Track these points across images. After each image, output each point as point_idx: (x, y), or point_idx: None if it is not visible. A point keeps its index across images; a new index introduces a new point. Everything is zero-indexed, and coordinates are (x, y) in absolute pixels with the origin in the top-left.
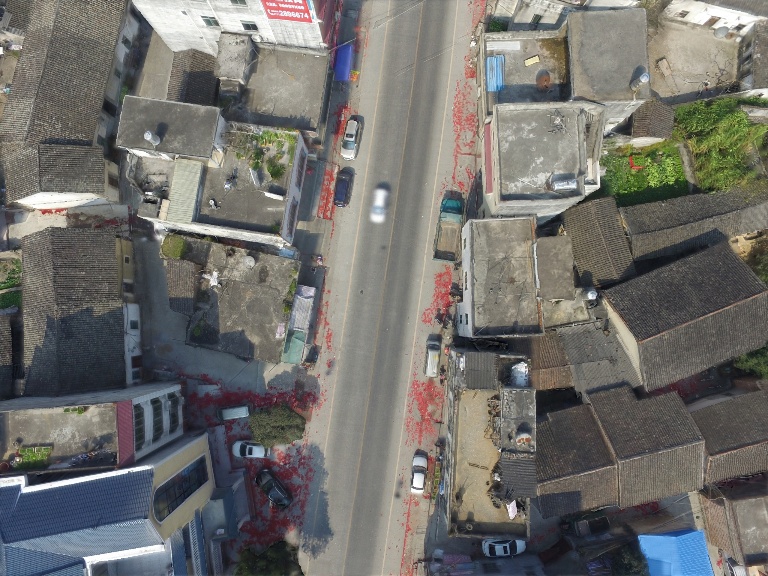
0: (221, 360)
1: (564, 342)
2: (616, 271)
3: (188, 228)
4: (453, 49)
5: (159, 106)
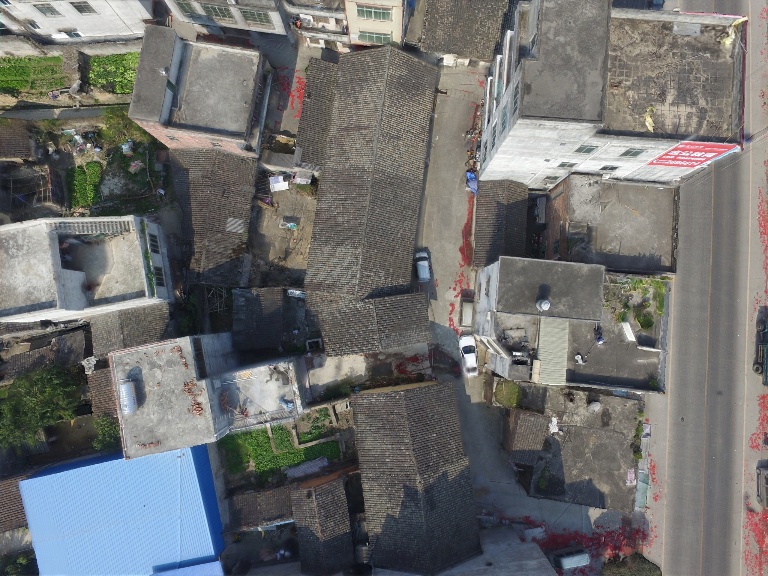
0: (542, 500)
1: None
2: None
3: None
4: (751, 154)
5: (538, 266)
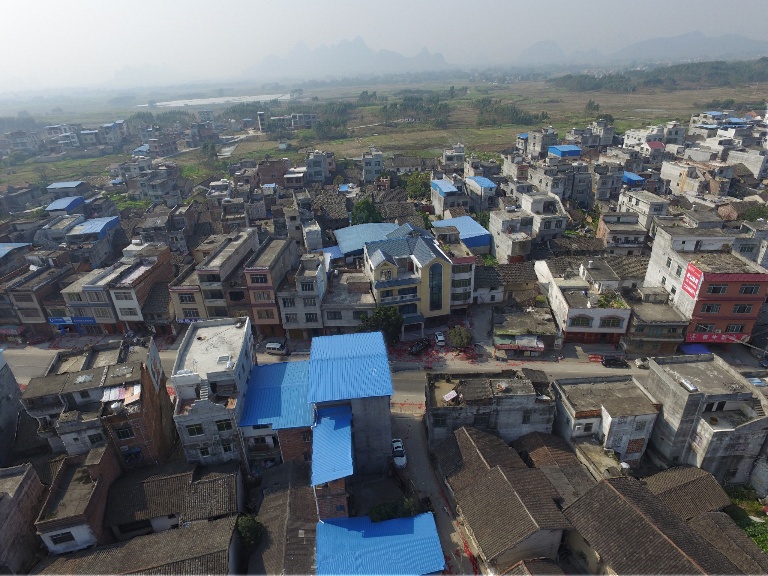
0: (484, 328)
1: (575, 466)
2: (660, 493)
3: None
4: None
5: None
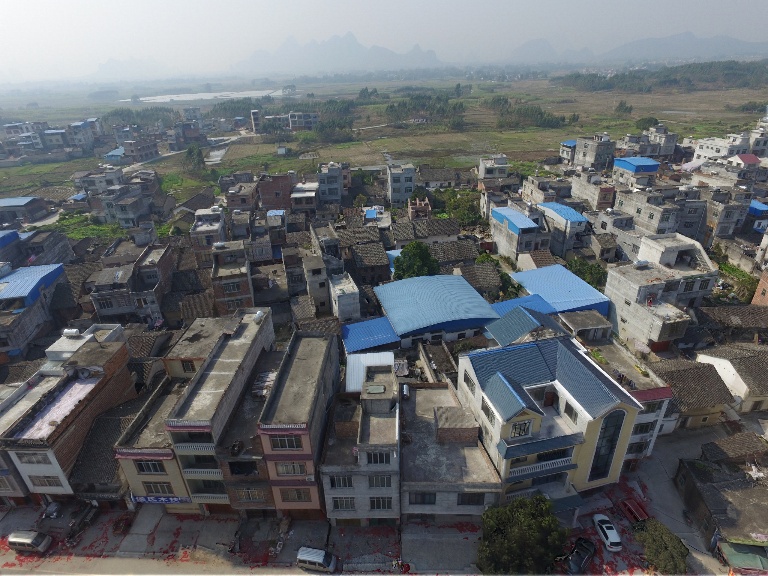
0: (669, 499)
1: None
2: None
3: None
4: None
5: None
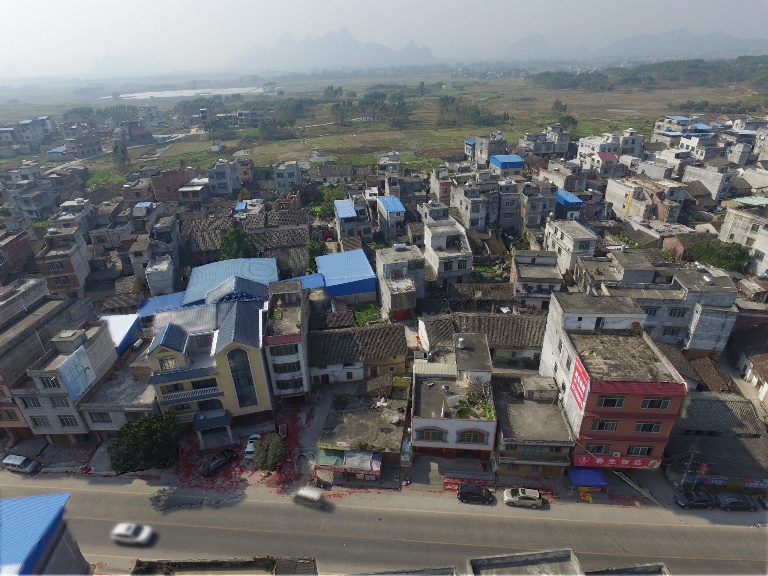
0: None
1: None
2: None
3: None
4: None
5: (484, 347)
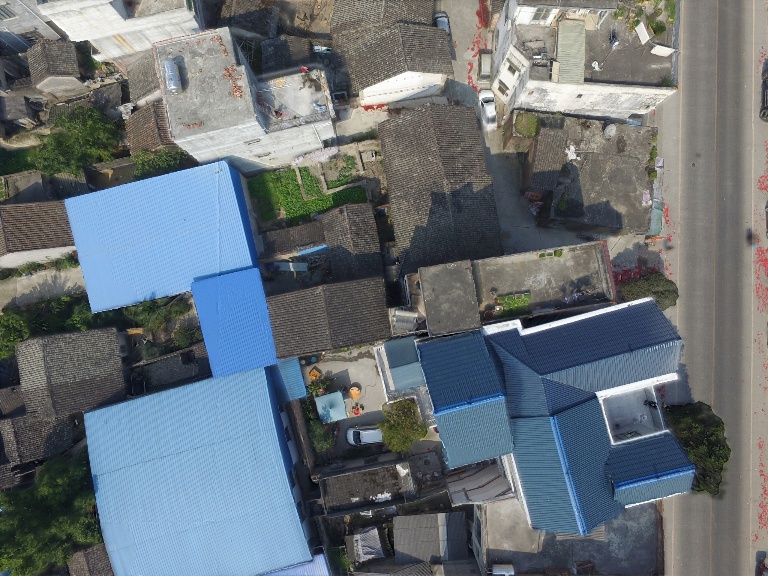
0: (561, 242)
1: None
2: None
3: (552, 100)
4: None
5: None
